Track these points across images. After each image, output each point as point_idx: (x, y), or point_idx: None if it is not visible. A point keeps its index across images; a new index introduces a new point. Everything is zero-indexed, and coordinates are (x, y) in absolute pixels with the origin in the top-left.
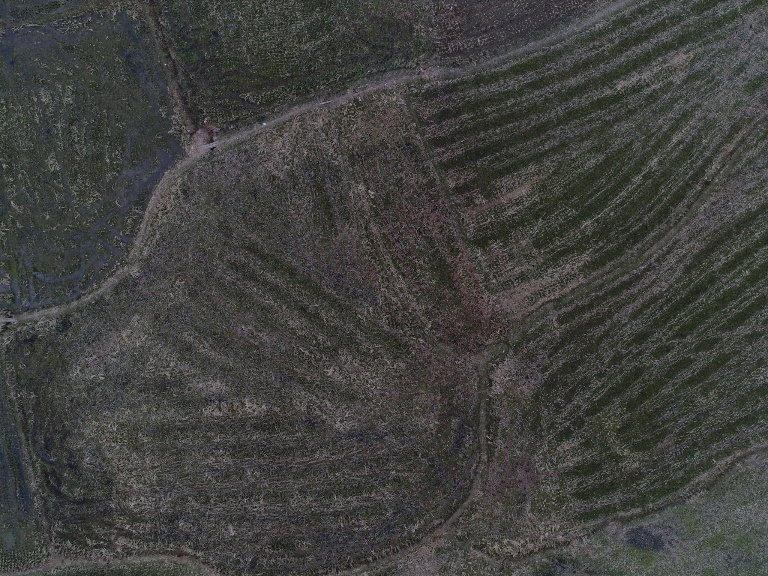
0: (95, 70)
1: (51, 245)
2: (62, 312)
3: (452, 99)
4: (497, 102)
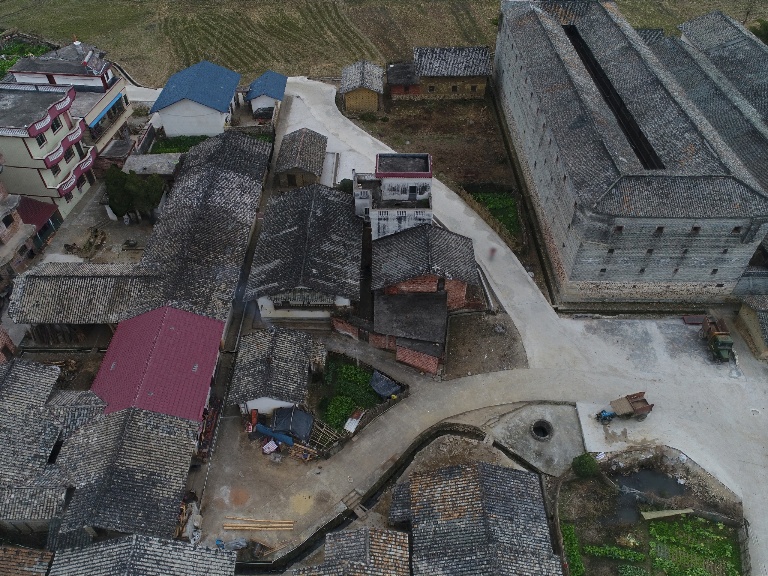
0: None
1: None
2: None
3: (331, 7)
4: None
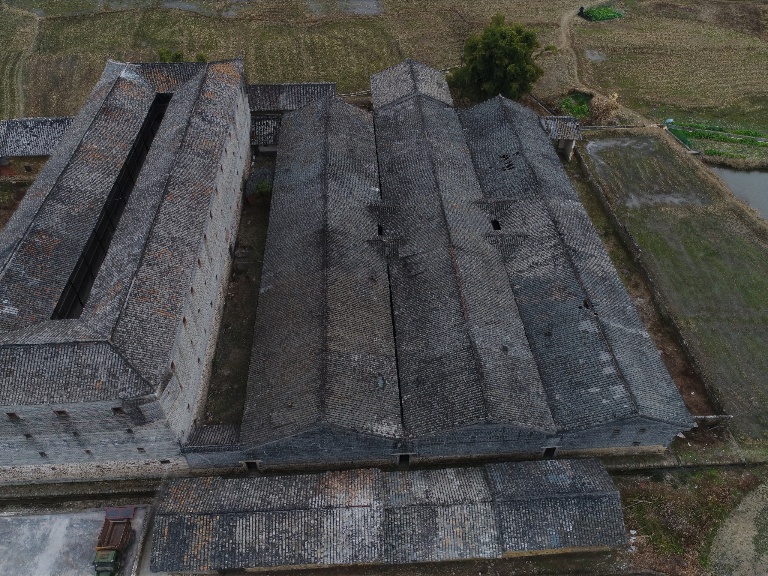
0: (84, 6)
1: (29, 0)
2: (3, 0)
3: None
4: (3, 65)
